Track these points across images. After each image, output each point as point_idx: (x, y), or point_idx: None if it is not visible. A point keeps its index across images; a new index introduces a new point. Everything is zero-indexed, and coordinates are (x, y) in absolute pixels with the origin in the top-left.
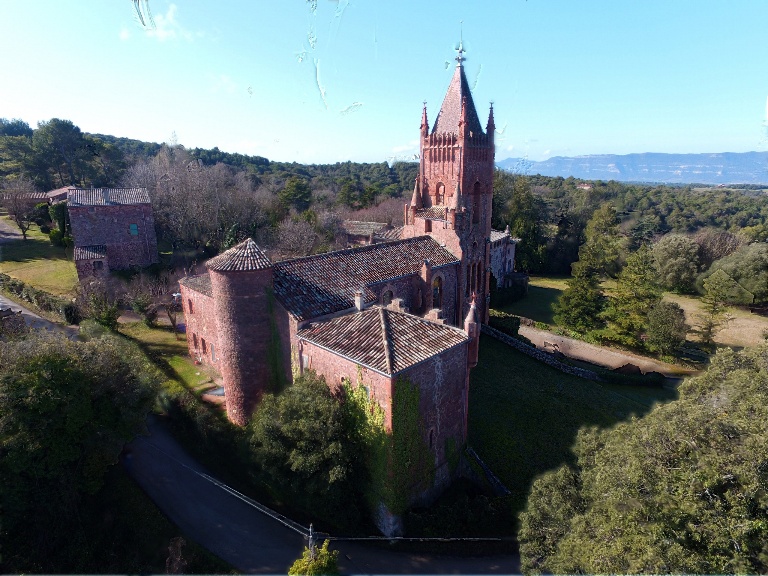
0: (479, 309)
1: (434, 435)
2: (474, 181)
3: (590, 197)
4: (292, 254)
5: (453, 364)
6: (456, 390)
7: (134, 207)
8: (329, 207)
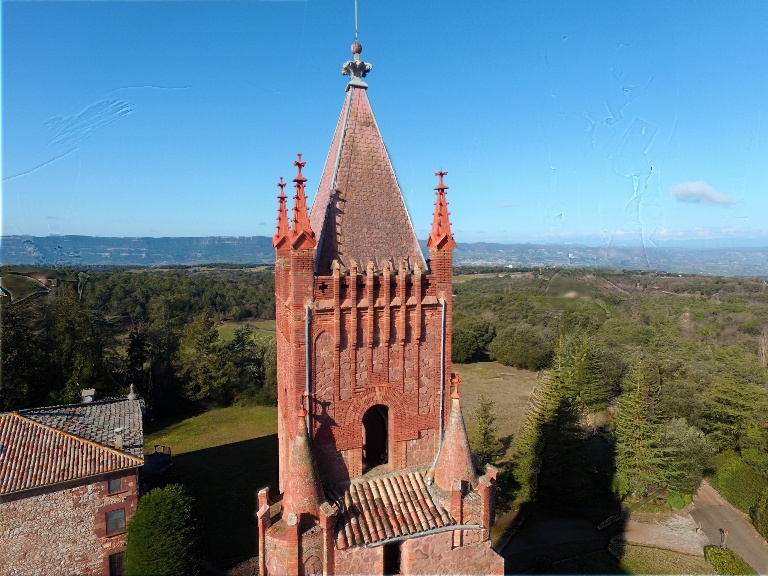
0: None
1: None
2: None
3: (169, 307)
4: None
5: None
6: None
7: None
8: None
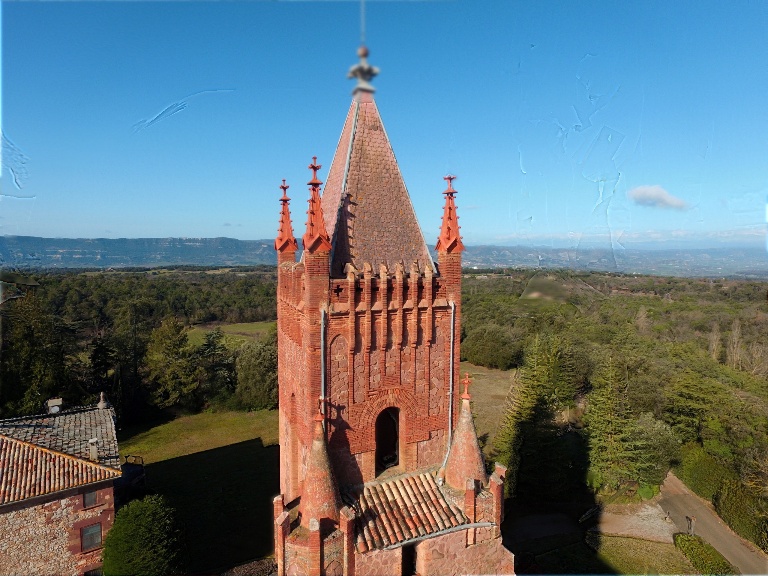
0: None
1: None
2: None
3: (135, 312)
4: None
5: None
6: None
7: None
8: None
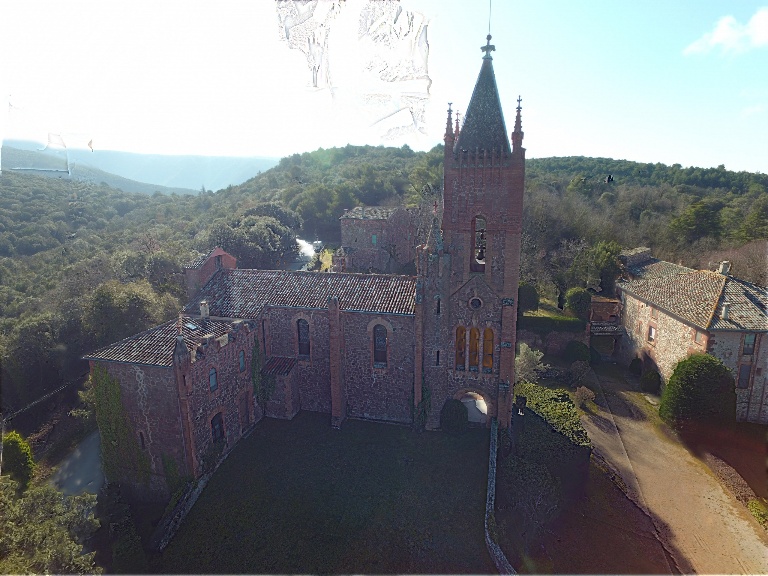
0: (491, 396)
1: (146, 439)
2: (471, 214)
3: None
4: None
5: (160, 384)
6: (170, 412)
7: (377, 222)
8: (578, 239)
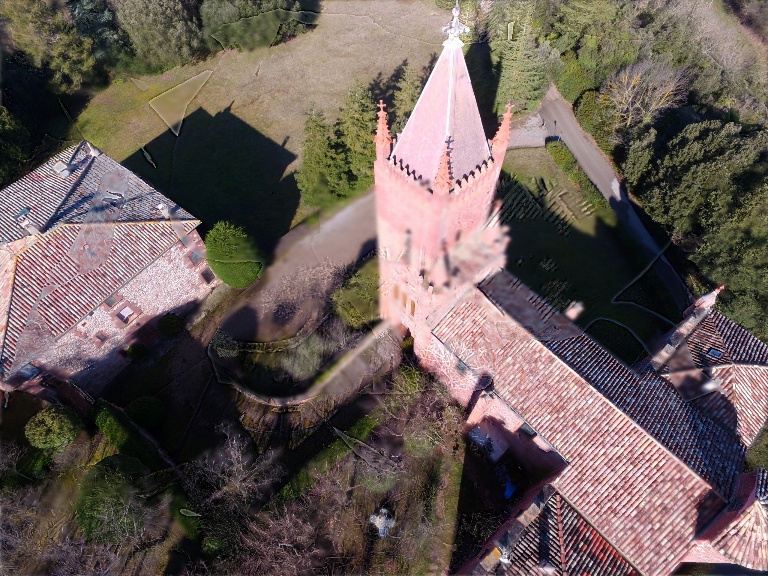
0: None
1: None
2: None
3: None
4: (89, 575)
5: None
6: None
7: None
8: None
